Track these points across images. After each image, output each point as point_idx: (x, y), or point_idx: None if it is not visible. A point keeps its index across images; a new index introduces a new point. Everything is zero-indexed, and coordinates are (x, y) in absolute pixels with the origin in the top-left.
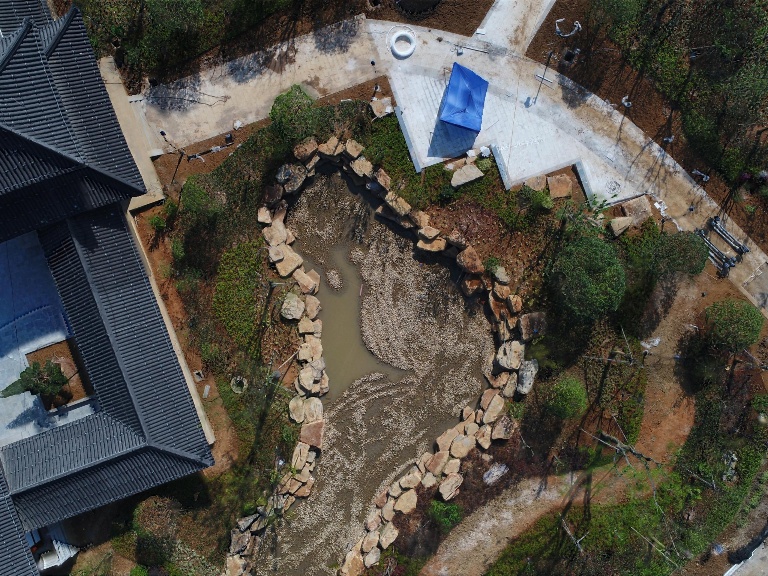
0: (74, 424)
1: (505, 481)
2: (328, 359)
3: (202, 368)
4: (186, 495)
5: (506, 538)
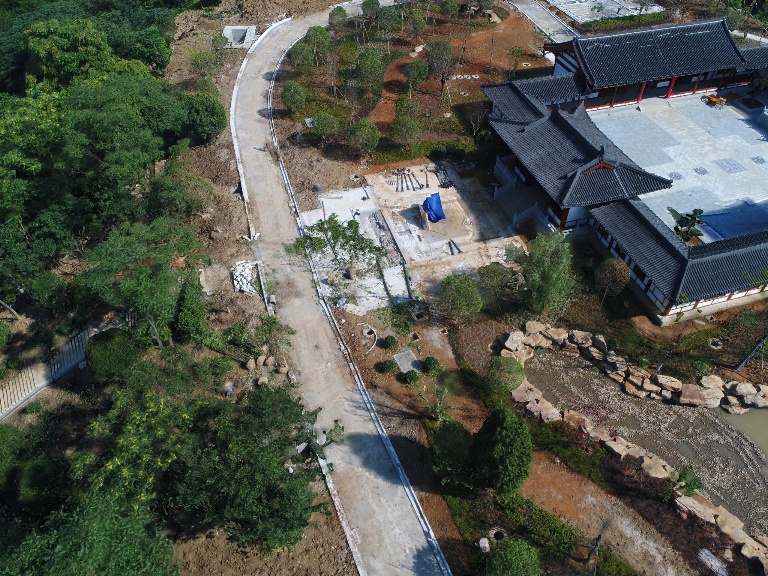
0: (675, 233)
1: (710, 574)
2: (759, 415)
3: (718, 321)
4: (614, 304)
5: (643, 571)
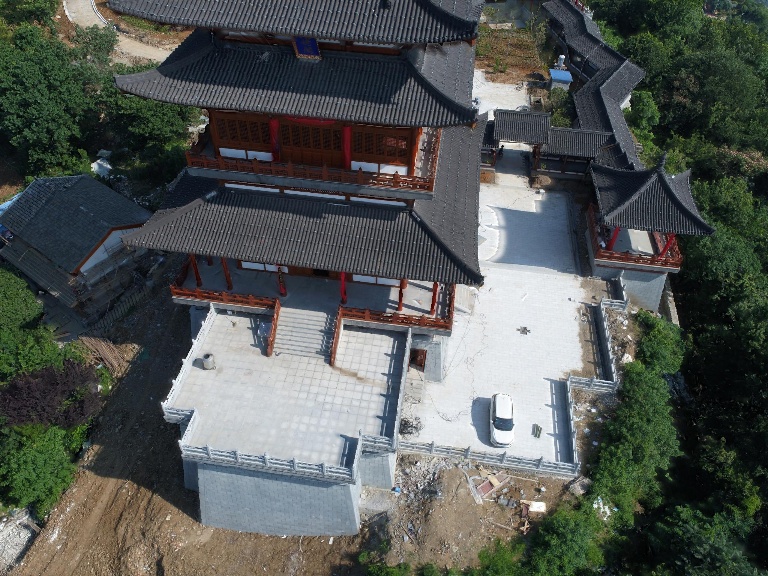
0: None
1: None
2: None
3: None
4: None
5: None
